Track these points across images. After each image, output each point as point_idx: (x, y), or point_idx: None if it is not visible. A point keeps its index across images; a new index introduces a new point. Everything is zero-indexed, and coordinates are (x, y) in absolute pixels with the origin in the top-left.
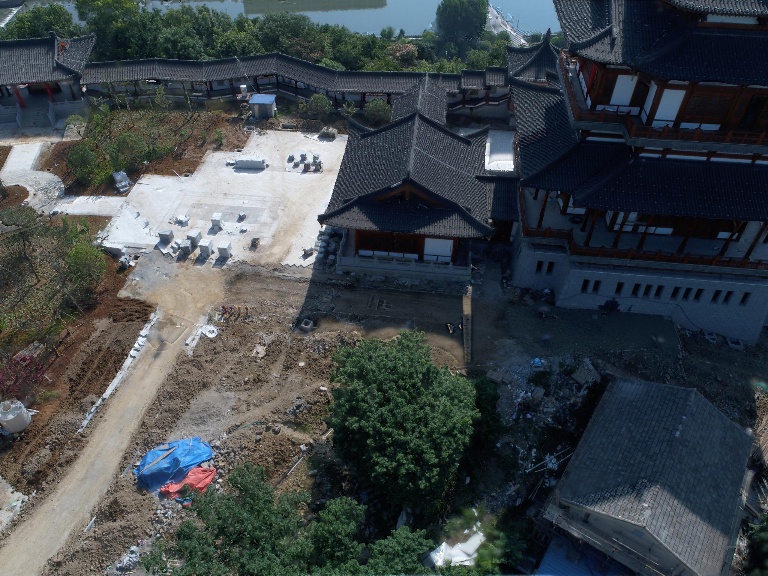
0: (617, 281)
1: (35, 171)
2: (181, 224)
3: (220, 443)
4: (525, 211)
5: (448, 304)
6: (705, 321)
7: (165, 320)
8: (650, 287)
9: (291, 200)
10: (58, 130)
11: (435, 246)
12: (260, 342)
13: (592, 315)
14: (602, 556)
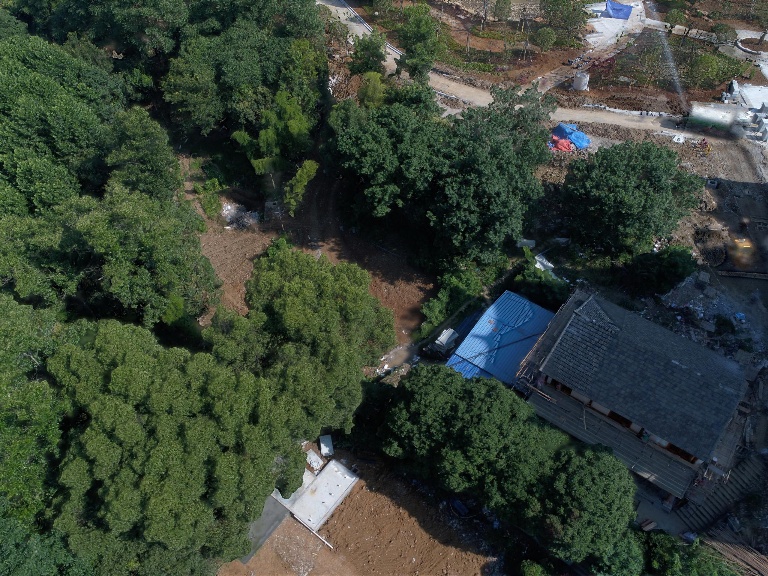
0: None
1: None
2: None
3: (590, 151)
4: None
5: None
6: None
7: (679, 121)
8: None
9: None
10: None
11: None
12: None
13: None
14: None
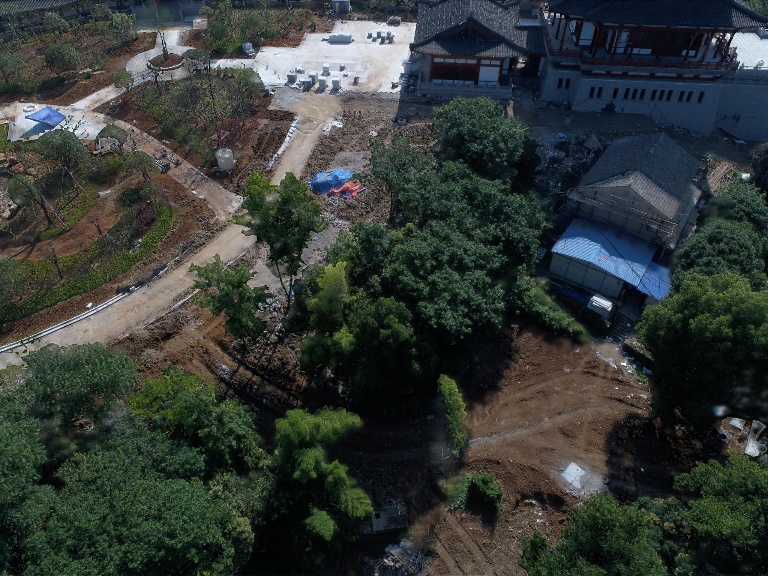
0: (614, 87)
1: (181, 46)
2: (300, 72)
3: (360, 172)
4: (550, 41)
5: None
6: (675, 117)
7: (305, 120)
8: (636, 91)
9: (375, 59)
10: (187, 23)
11: (487, 73)
12: (372, 129)
13: (597, 114)
14: (605, 221)
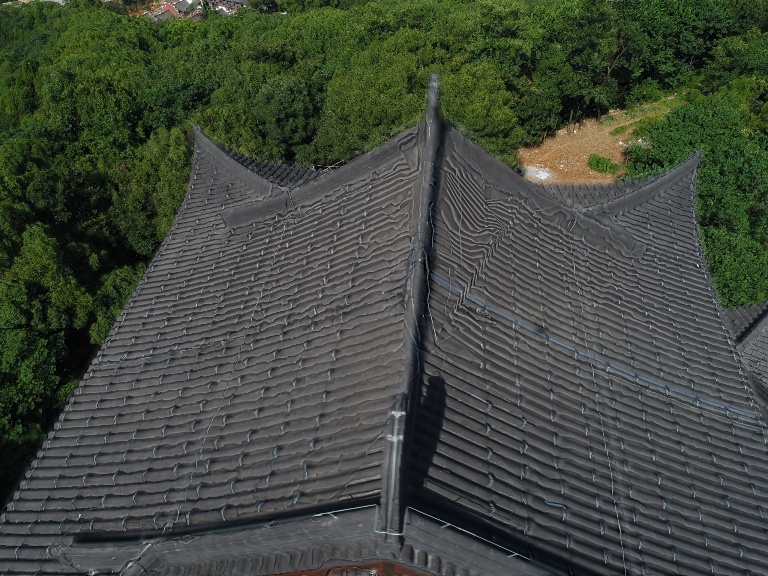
0: None
1: None
2: None
3: None
4: None
5: None
6: None
7: None
8: None
9: None
10: None
11: None
12: None
13: None
14: None
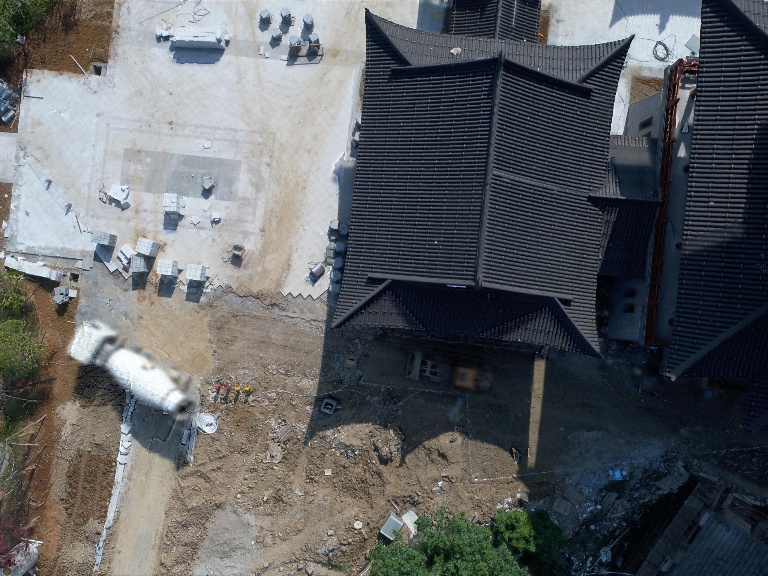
0: None
1: None
2: (119, 203)
3: None
4: (658, 305)
5: (514, 369)
6: None
7: (146, 403)
8: None
9: (278, 140)
10: None
11: None
12: (273, 438)
13: (705, 391)
14: None
